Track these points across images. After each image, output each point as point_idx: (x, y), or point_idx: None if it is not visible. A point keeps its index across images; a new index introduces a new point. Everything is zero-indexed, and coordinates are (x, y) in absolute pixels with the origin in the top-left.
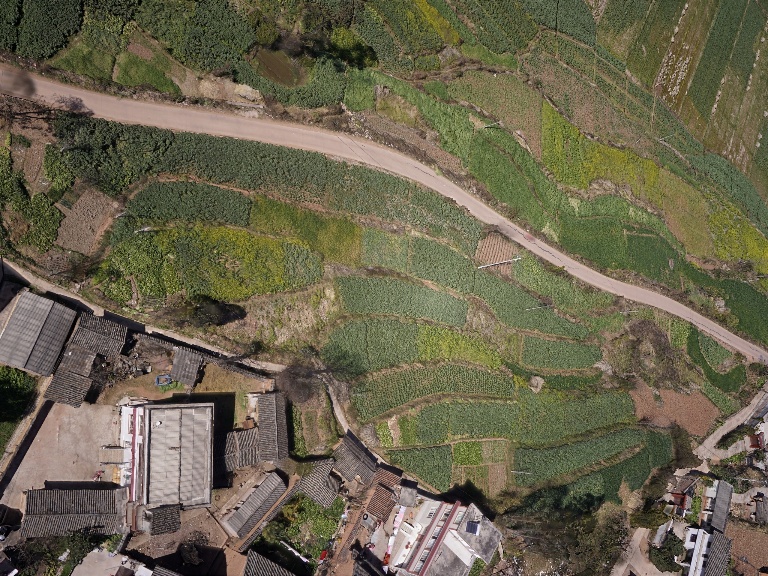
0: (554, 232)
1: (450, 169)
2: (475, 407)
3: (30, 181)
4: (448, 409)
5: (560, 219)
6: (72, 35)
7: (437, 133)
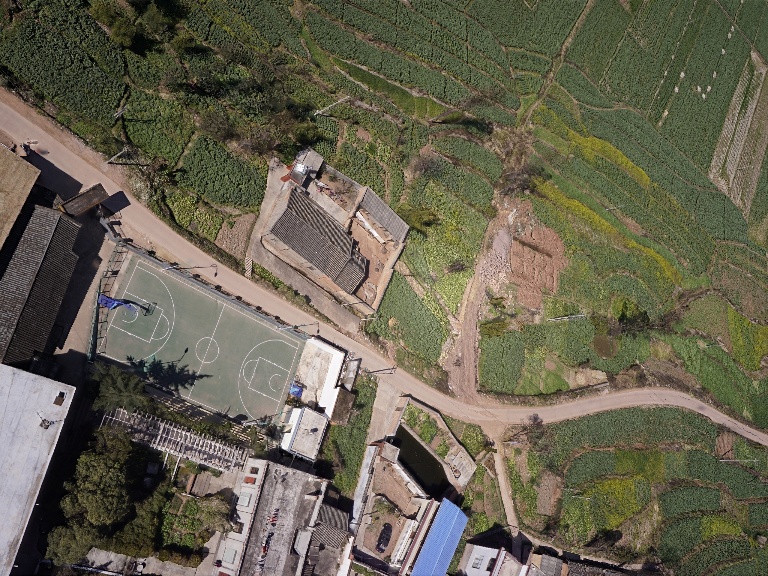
0: (749, 413)
1: (693, 387)
2: (735, 569)
3: (522, 475)
4: (722, 574)
5: (751, 401)
6: (521, 367)
7: (682, 361)
